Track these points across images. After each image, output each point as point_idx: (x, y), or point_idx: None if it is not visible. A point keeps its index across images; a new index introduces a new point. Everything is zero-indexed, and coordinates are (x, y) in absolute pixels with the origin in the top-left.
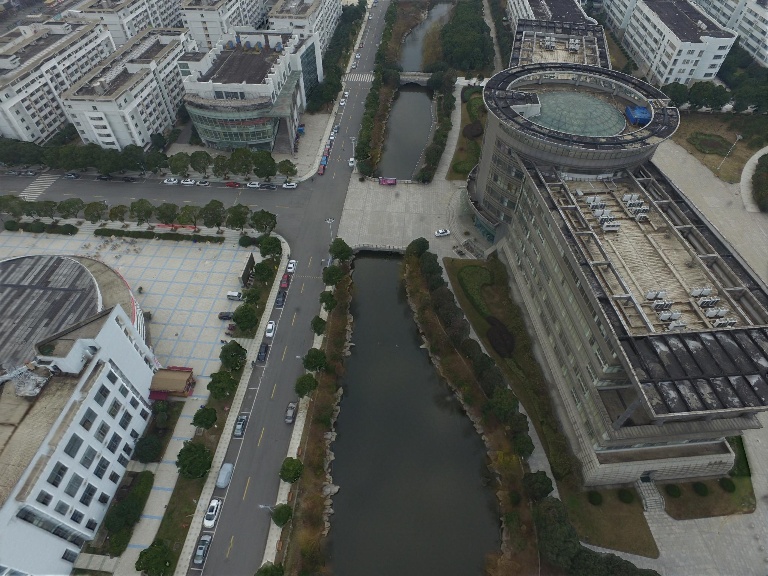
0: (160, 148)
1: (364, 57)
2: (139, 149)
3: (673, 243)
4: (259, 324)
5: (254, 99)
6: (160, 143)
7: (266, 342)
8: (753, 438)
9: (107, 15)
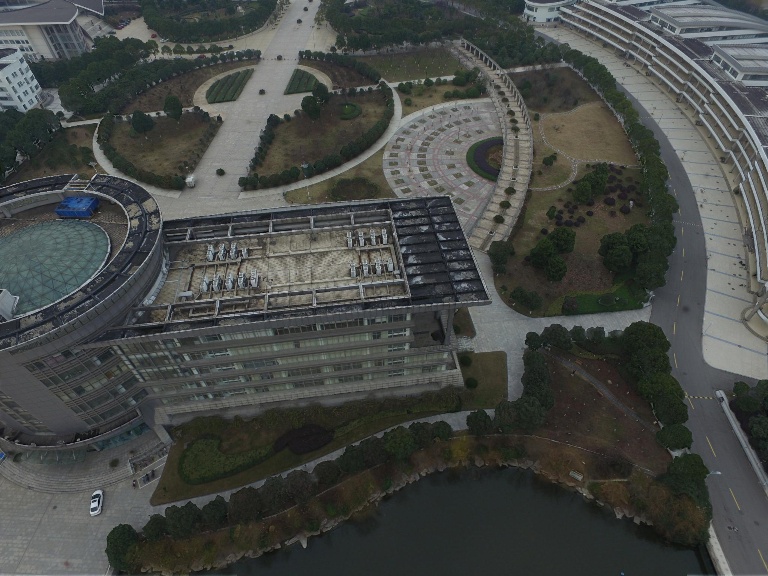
0: None
1: None
2: None
3: (282, 242)
4: None
5: None
6: None
7: None
8: None
9: None
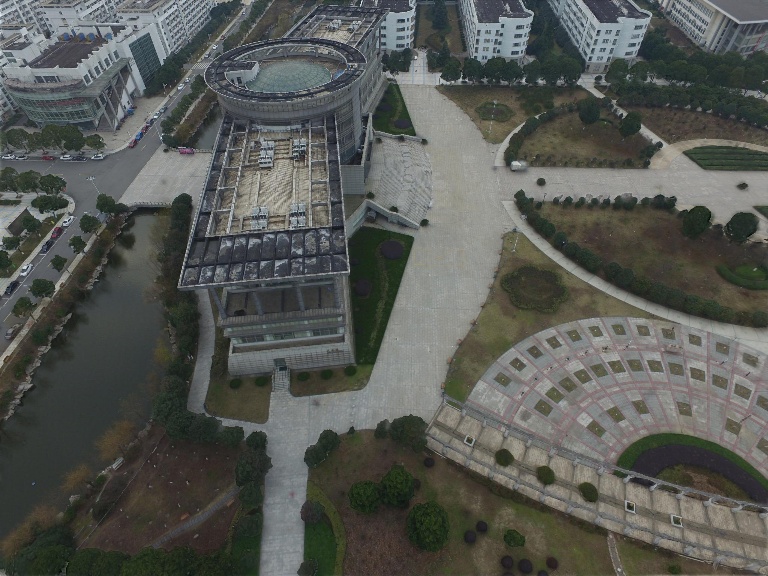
0: None
1: (221, 48)
2: None
3: (312, 175)
4: (19, 267)
5: (66, 81)
6: None
7: (19, 280)
8: (393, 337)
9: None
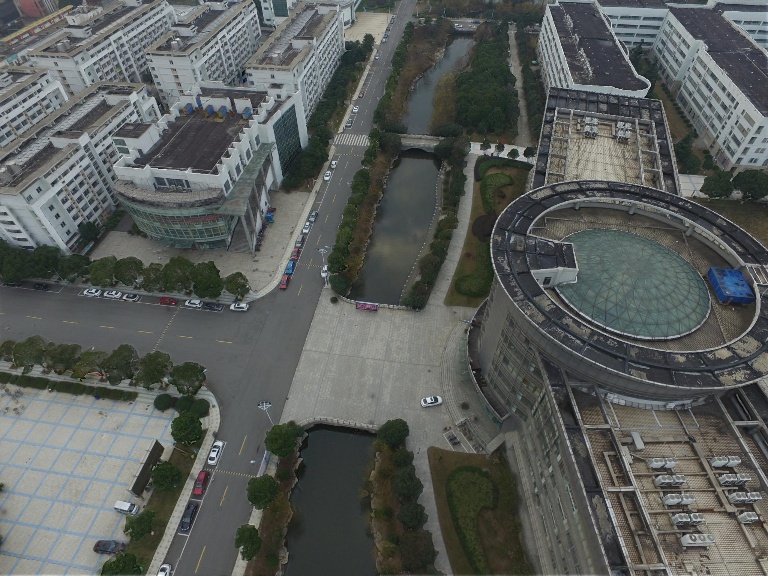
0: (90, 241)
1: (363, 111)
2: (51, 253)
3: None
4: (148, 567)
5: (200, 192)
6: (89, 235)
7: None
8: None
9: (62, 60)
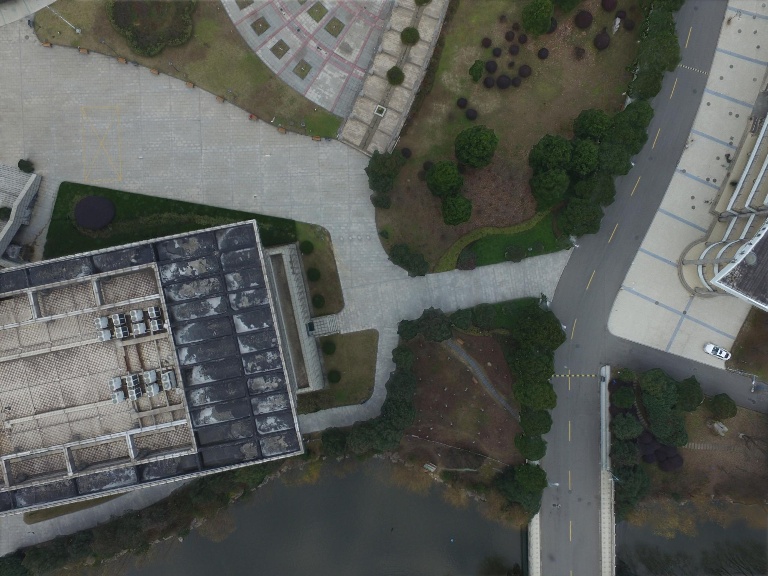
0: None
1: None
2: None
3: None
4: None
5: None
6: None
7: None
8: (253, 201)
9: None
